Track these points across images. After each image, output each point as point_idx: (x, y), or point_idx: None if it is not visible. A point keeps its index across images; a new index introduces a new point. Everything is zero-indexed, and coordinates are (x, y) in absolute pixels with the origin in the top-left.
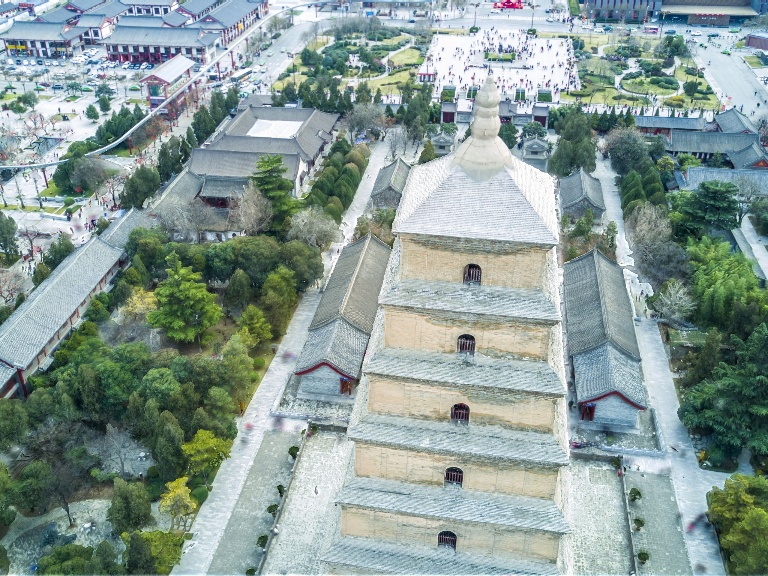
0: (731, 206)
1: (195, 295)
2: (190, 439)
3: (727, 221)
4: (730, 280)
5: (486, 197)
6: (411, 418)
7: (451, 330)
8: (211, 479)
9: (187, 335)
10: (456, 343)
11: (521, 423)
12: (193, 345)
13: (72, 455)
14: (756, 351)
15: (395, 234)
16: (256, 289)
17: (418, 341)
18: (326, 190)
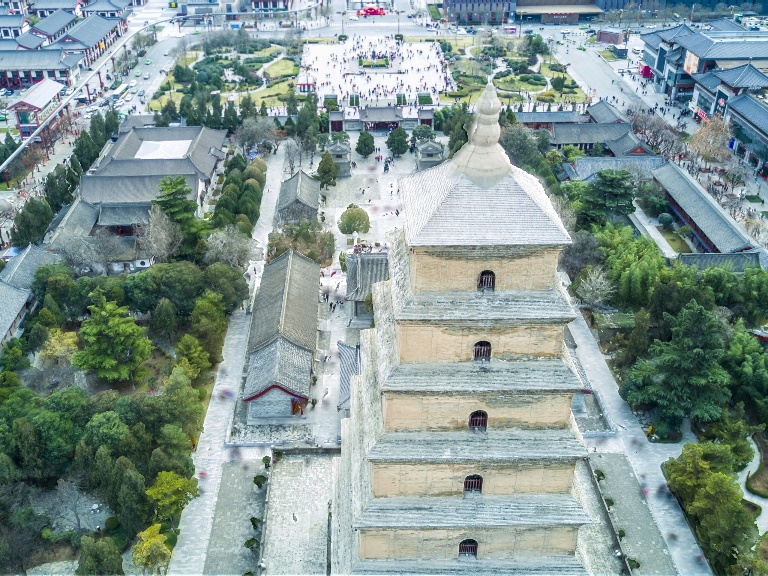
0: (627, 192)
1: (125, 330)
2: (149, 483)
3: (624, 206)
4: (644, 262)
5: (495, 203)
6: (429, 431)
7: (467, 338)
8: (176, 522)
9: (120, 373)
10: (472, 351)
11: (538, 422)
12: (124, 383)
13: (19, 518)
14: (689, 326)
15: (410, 248)
16: (181, 317)
17: (434, 353)
18: (231, 208)
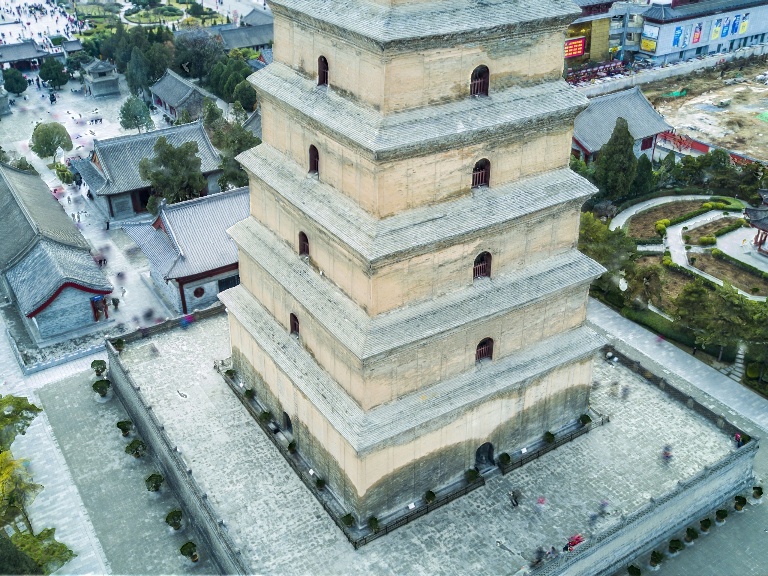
0: None
1: None
2: None
3: None
4: None
5: None
6: (432, 106)
7: None
8: None
9: None
10: None
11: (536, 74)
12: None
13: None
14: None
15: None
16: None
17: None
18: None
